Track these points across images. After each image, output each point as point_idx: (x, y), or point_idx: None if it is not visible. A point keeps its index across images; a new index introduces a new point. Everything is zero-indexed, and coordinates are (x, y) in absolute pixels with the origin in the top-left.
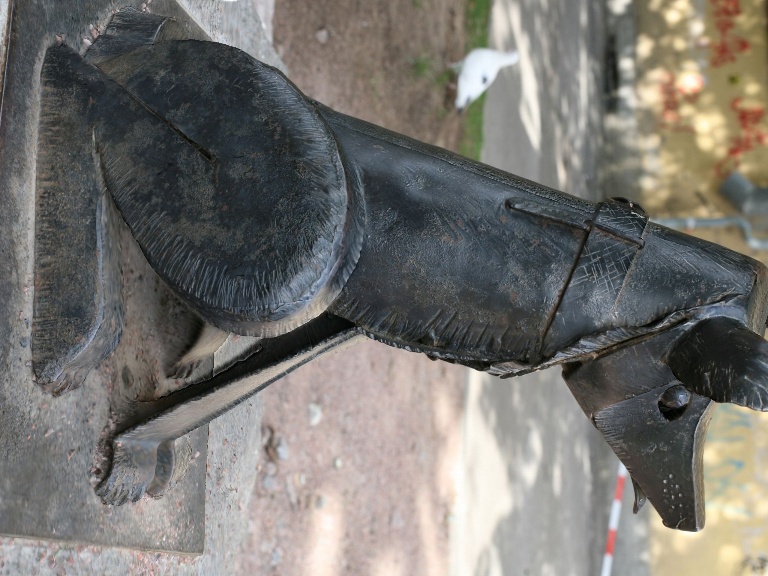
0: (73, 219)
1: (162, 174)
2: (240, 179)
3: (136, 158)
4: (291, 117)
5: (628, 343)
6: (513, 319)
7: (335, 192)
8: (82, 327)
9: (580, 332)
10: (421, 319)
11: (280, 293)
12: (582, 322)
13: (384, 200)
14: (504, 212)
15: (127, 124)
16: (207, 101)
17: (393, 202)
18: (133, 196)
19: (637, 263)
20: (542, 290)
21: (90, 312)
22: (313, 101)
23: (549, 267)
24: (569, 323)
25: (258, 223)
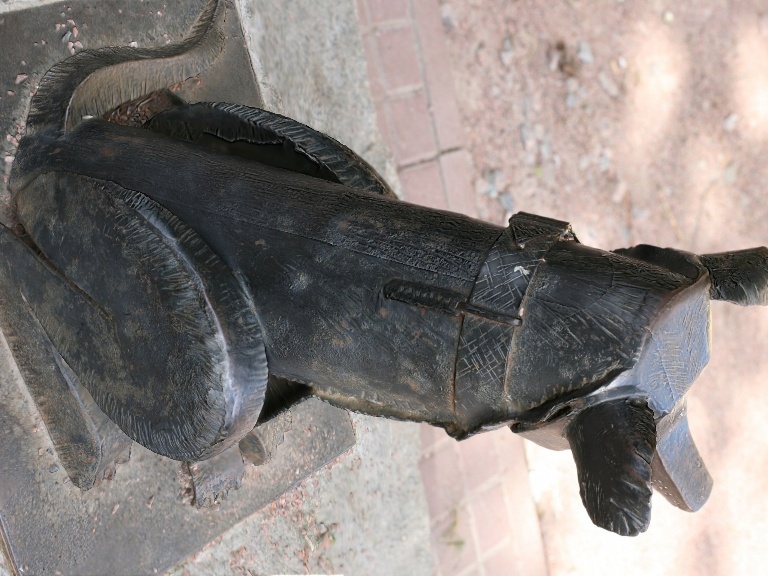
0: (43, 366)
1: (80, 334)
2: (134, 338)
3: (58, 318)
4: (156, 265)
5: (526, 427)
6: (423, 402)
7: (211, 340)
8: (88, 450)
9: (482, 415)
10: (355, 394)
11: (197, 442)
12: (481, 407)
13: (273, 309)
14: (383, 303)
15: (41, 285)
16: (89, 255)
17: (281, 310)
18: (69, 353)
19: (518, 343)
20: (435, 380)
21: (88, 438)
22: (242, 116)
23: (434, 359)
24: (470, 407)
25: (159, 382)
